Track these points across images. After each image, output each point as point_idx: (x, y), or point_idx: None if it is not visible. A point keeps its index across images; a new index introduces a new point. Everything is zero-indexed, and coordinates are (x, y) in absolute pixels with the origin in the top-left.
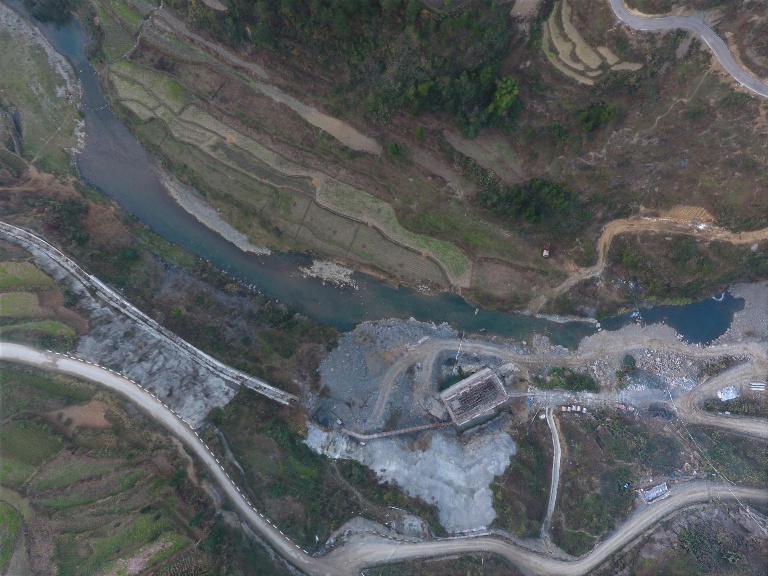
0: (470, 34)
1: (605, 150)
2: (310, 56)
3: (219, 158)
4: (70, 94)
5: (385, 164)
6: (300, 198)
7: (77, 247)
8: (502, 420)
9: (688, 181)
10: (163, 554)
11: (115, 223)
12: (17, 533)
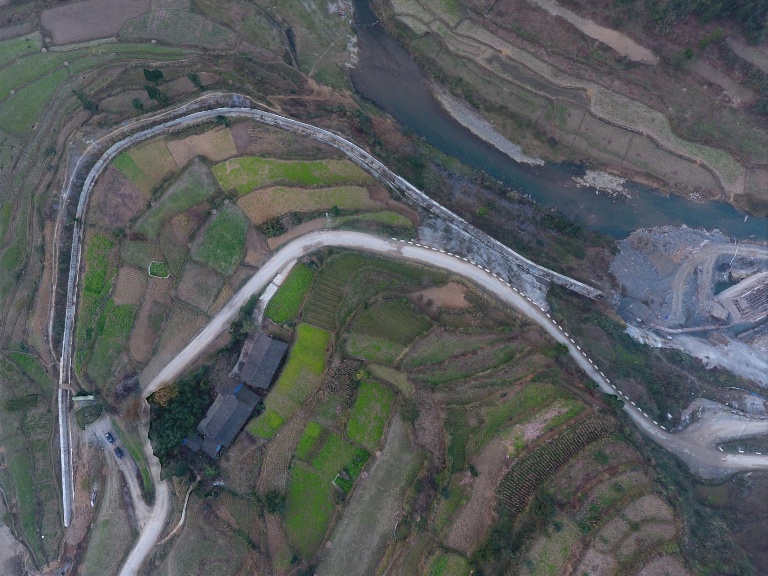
0: None
1: None
2: None
3: (494, 71)
4: (342, 10)
5: (659, 75)
6: (575, 109)
7: (381, 150)
8: None
9: None
10: (560, 419)
11: (396, 133)
12: (393, 409)
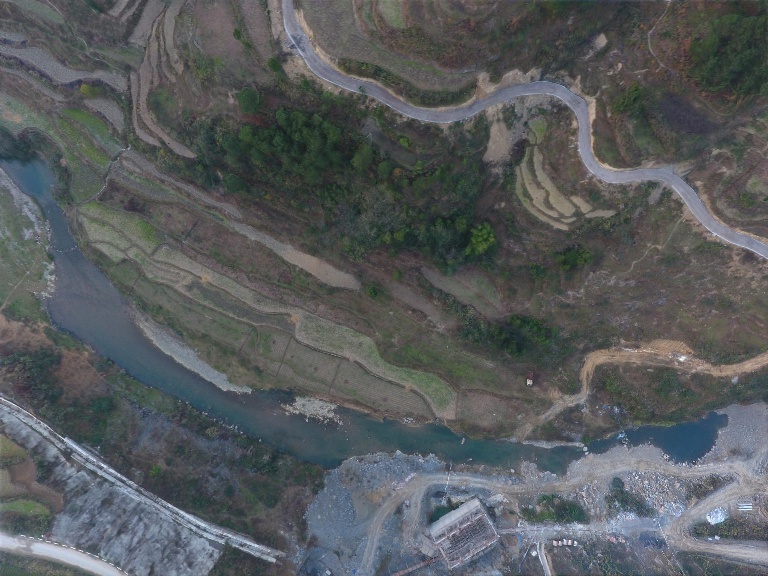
0: (443, 187)
1: (583, 290)
2: (283, 201)
3: (195, 298)
4: (38, 236)
5: (364, 298)
6: (279, 335)
7: (50, 407)
8: (494, 553)
9: (666, 318)
10: None
11: (89, 371)
12: None
